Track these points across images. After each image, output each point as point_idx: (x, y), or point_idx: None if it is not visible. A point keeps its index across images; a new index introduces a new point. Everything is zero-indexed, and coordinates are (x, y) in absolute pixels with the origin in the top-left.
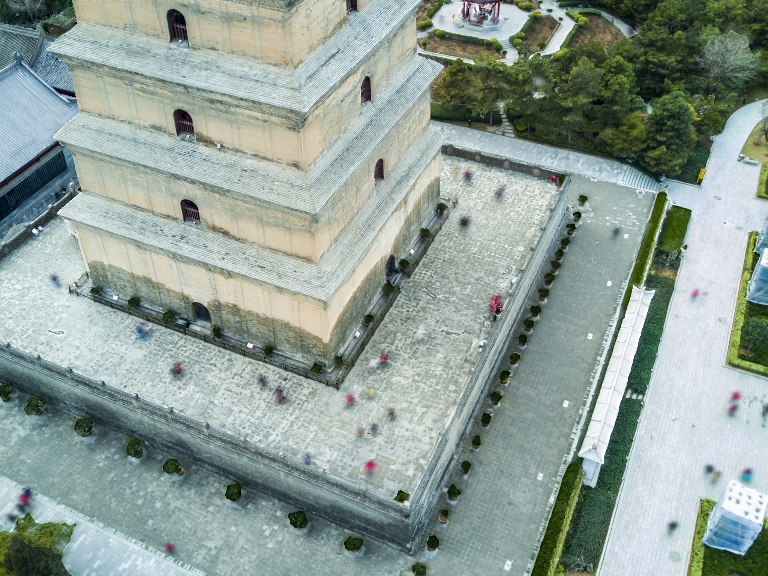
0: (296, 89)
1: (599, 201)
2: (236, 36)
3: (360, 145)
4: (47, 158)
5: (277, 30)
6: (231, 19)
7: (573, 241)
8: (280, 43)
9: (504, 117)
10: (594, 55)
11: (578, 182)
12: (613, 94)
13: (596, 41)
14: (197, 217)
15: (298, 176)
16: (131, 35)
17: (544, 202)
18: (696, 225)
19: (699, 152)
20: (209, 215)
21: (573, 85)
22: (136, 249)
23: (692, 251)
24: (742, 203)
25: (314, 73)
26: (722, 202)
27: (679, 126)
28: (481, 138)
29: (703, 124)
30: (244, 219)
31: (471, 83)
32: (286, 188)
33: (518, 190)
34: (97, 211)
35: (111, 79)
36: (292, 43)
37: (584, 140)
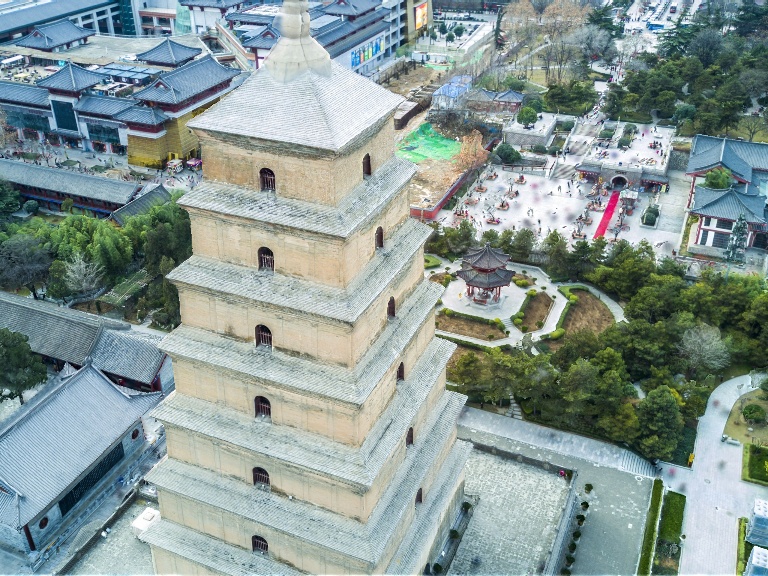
0: (362, 466)
1: (603, 488)
2: (313, 420)
3: (406, 488)
4: (109, 450)
5: (348, 421)
6: (310, 409)
7: (583, 532)
8: (350, 430)
9: (512, 398)
10: (588, 344)
11: (583, 468)
12: (608, 387)
13: (588, 331)
14: (265, 548)
15: (359, 528)
16: (222, 408)
17: (556, 497)
18: (691, 511)
19: (687, 433)
20: (277, 550)
21: (573, 380)
22: (207, 571)
23: (690, 539)
24: (730, 486)
25: (375, 447)
26: (712, 486)
27: (668, 417)
28: (493, 421)
29: (688, 407)
30: (309, 556)
31: (482, 371)
32: (349, 538)
33: (532, 485)
34: (174, 537)
35: (201, 439)
36: (359, 429)
37: (584, 423)
